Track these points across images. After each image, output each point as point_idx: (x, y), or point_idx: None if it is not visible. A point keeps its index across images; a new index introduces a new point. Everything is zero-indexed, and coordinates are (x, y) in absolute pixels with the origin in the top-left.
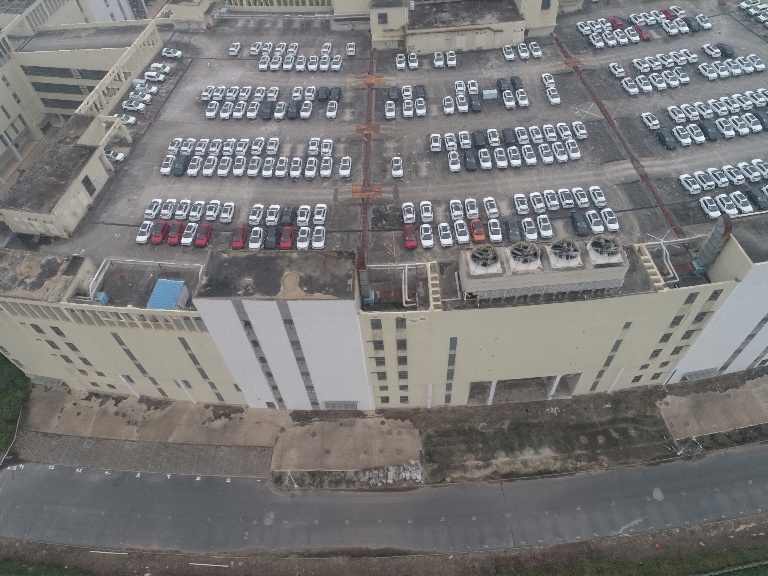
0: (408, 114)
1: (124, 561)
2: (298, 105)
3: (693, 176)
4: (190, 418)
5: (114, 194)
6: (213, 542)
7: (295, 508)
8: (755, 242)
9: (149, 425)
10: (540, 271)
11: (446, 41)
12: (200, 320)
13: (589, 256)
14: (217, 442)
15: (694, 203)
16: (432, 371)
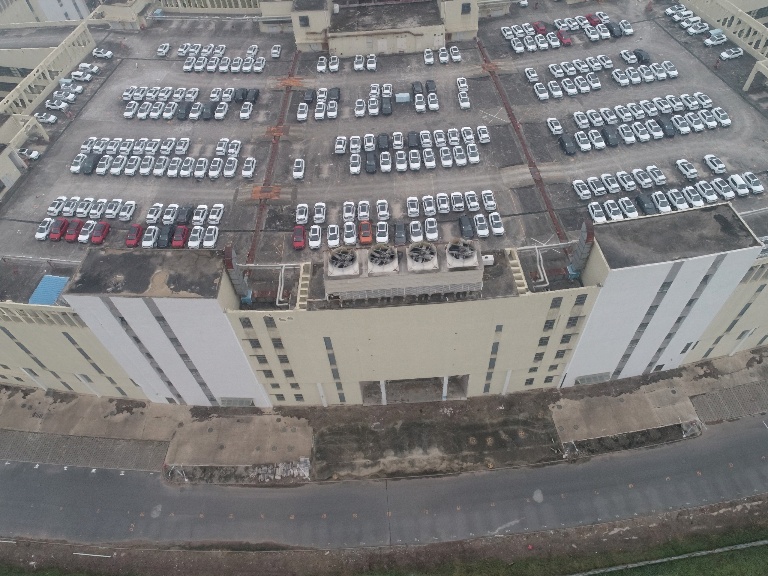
0: (319, 116)
1: (12, 549)
2: (214, 106)
3: (586, 181)
4: (93, 412)
5: (23, 191)
6: (99, 533)
7: (183, 502)
8: (617, 248)
9: (53, 418)
10: (395, 273)
11: (367, 44)
12: (77, 316)
13: (446, 259)
14: (116, 436)
15: (583, 208)
16: (316, 370)
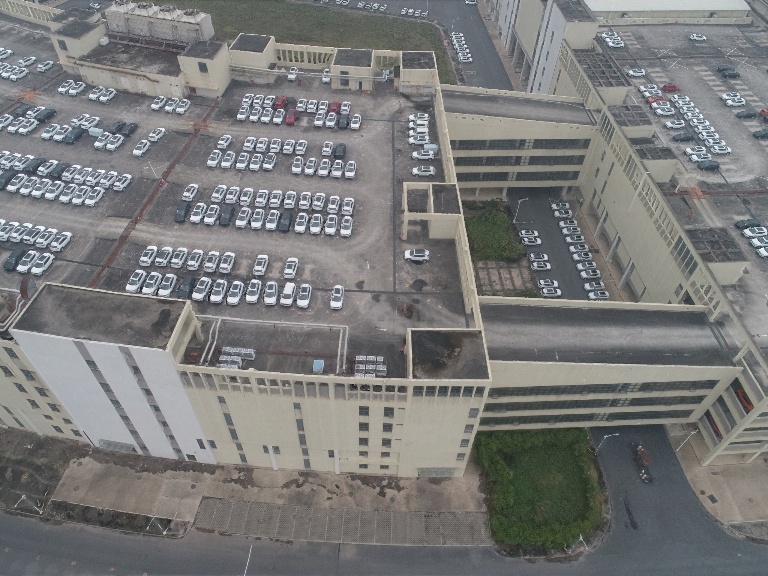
0: (10, 129)
1: None
2: None
3: (160, 250)
4: None
5: None
6: None
7: None
8: (44, 312)
9: None
10: None
11: (112, 79)
12: None
13: None
14: None
15: None
16: None
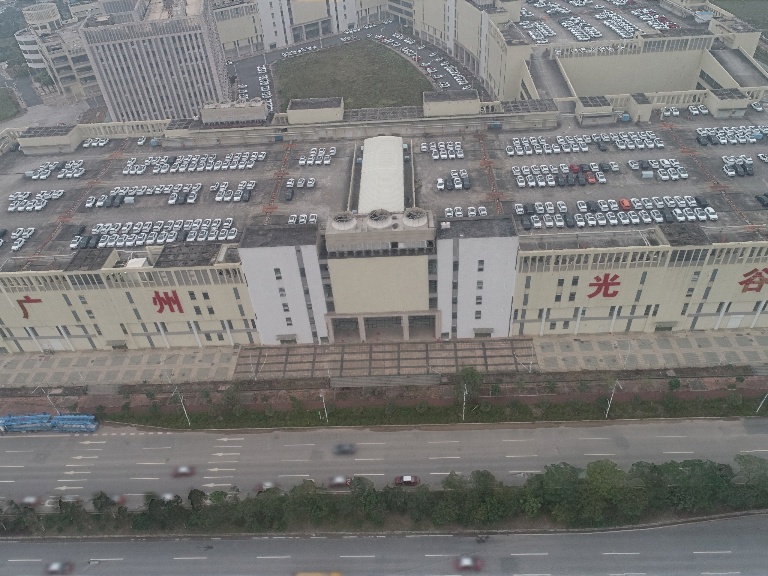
0: None
1: None
2: None
3: None
4: None
5: None
6: None
7: None
8: None
9: None
10: None
11: None
12: None
13: None
14: None
15: None
16: None
